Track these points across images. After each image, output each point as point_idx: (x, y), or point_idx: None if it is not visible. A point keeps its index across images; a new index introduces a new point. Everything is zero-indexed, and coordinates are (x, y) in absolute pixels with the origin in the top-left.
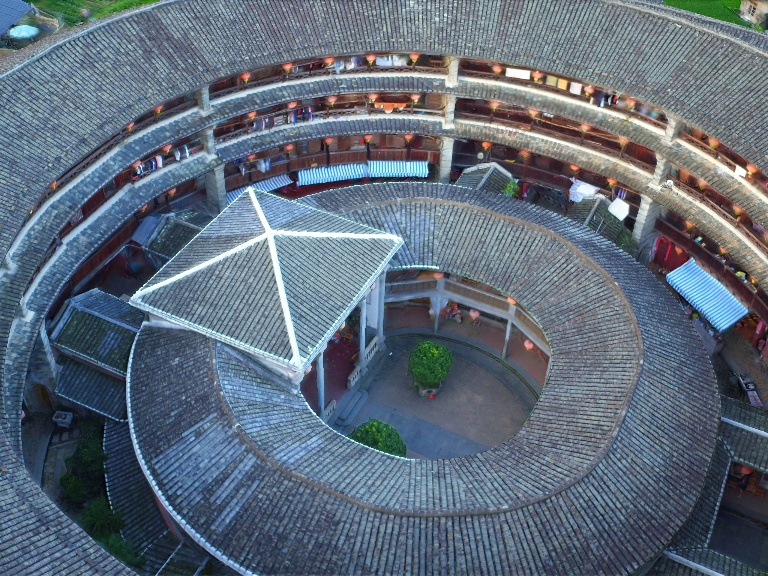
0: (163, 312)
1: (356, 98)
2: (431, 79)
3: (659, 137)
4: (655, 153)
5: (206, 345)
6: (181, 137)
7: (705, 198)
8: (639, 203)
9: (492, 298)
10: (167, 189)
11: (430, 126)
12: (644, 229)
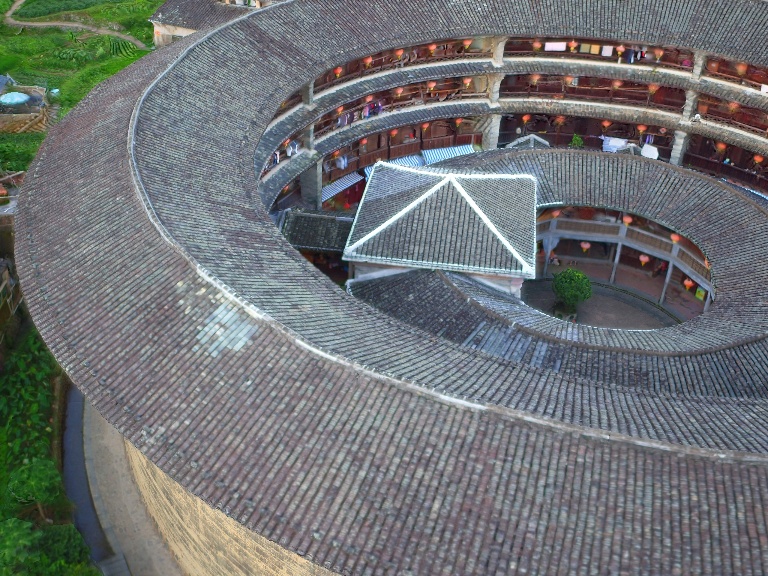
0: (383, 258)
1: (416, 89)
2: (479, 63)
3: (686, 78)
4: (688, 91)
5: (435, 277)
6: (300, 129)
7: (733, 122)
8: (665, 144)
9: (603, 226)
10: (289, 182)
11: (479, 107)
12: (678, 163)
